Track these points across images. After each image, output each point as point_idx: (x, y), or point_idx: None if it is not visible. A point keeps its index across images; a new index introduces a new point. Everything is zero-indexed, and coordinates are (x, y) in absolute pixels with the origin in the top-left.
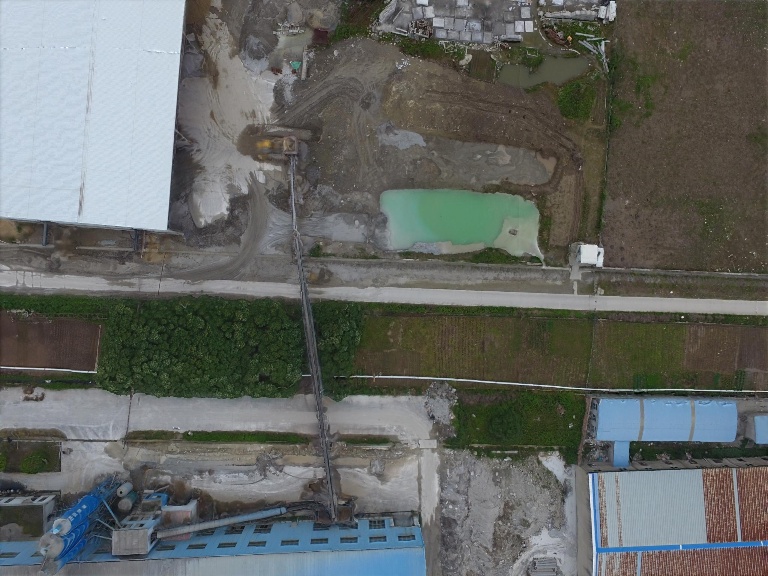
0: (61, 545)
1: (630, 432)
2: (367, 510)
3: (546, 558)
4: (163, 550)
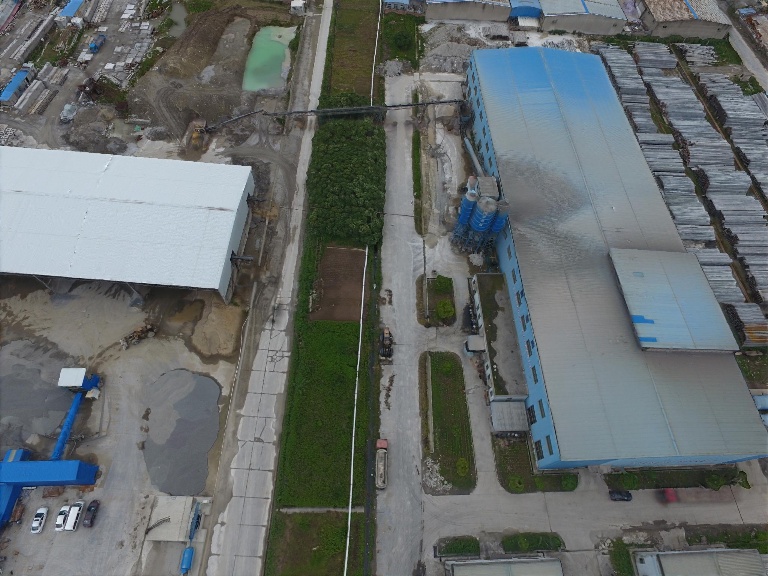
0: None
1: None
2: None
3: (483, 32)
4: None
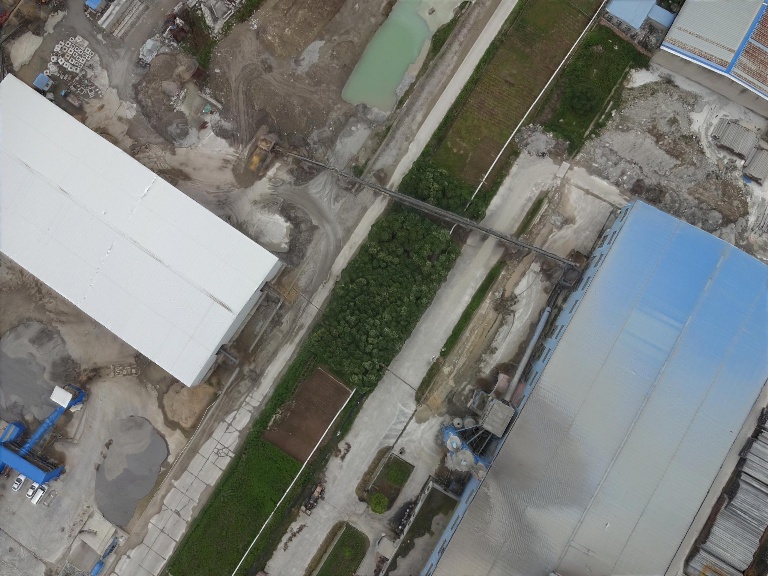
0: (468, 453)
1: None
2: (589, 247)
3: (716, 125)
4: (520, 403)
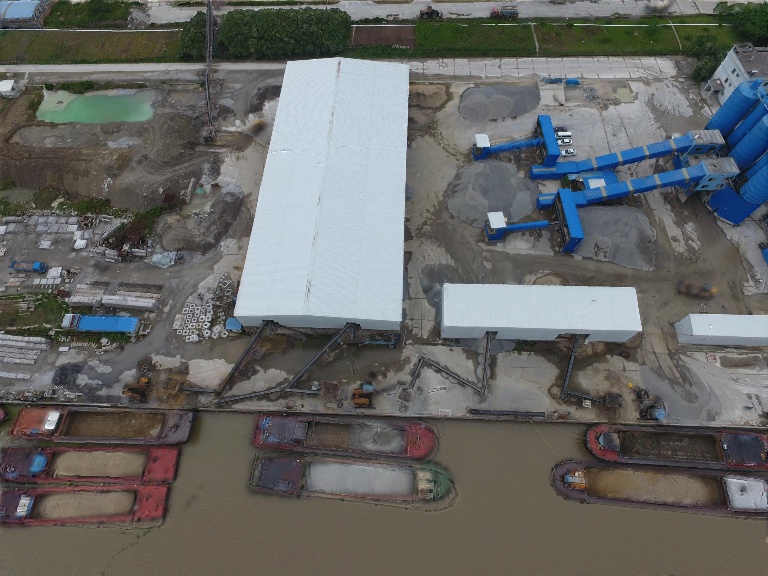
0: None
1: (18, 3)
2: None
3: None
4: None
